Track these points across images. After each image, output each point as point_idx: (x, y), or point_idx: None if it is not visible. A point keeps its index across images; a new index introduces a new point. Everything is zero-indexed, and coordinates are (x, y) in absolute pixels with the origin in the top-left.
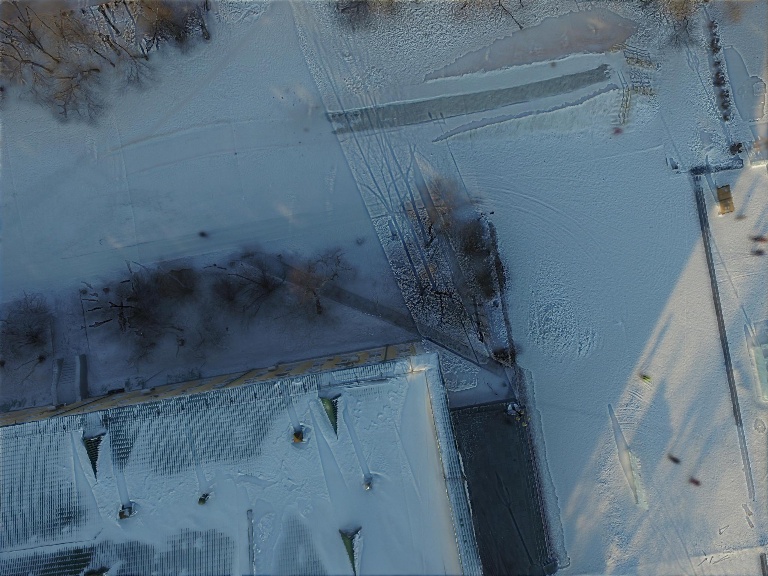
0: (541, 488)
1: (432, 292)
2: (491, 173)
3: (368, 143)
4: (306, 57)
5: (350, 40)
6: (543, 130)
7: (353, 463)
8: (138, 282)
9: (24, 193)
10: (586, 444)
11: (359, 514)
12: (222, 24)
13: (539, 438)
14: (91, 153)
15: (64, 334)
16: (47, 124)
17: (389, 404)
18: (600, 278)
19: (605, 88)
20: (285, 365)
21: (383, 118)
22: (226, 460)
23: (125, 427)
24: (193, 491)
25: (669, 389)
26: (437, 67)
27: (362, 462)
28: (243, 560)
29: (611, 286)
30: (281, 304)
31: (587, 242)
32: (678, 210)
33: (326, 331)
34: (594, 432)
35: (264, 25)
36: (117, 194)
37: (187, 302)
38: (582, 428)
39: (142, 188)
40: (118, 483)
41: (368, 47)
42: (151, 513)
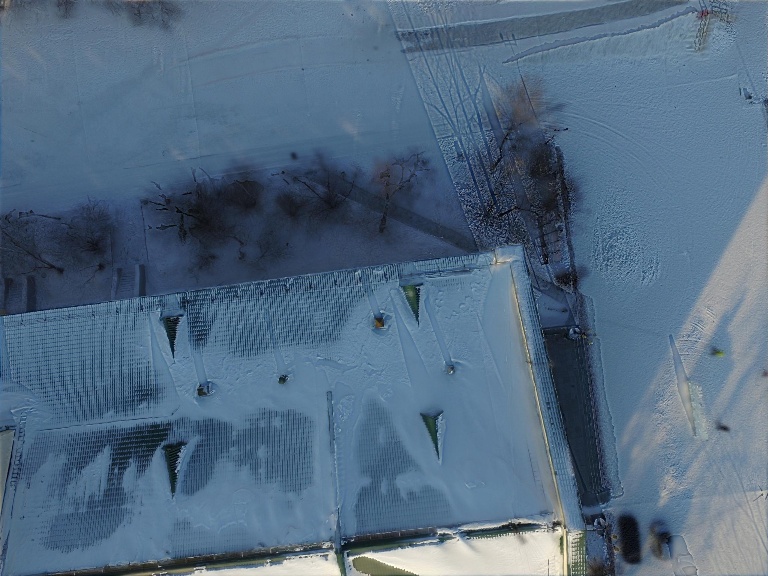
0: (597, 416)
1: (496, 215)
2: (561, 97)
3: (437, 62)
4: None
5: None
6: (616, 55)
7: (434, 350)
8: (201, 193)
9: (89, 102)
10: (645, 374)
11: (441, 399)
12: None
13: (598, 366)
14: (157, 64)
15: (124, 244)
16: (115, 33)
17: (471, 295)
18: (667, 207)
19: (683, 11)
20: None
21: (453, 38)
22: (305, 344)
23: (203, 310)
24: (271, 373)
25: (732, 322)
26: None
27: (443, 350)
28: (323, 438)
29: (678, 215)
30: (343, 221)
31: (655, 170)
32: (749, 141)
33: (387, 250)
34: (654, 362)
35: None
36: (182, 106)
37: (250, 214)
38: (642, 357)
39: (207, 101)
40: (195, 363)
41: None
42: (229, 392)
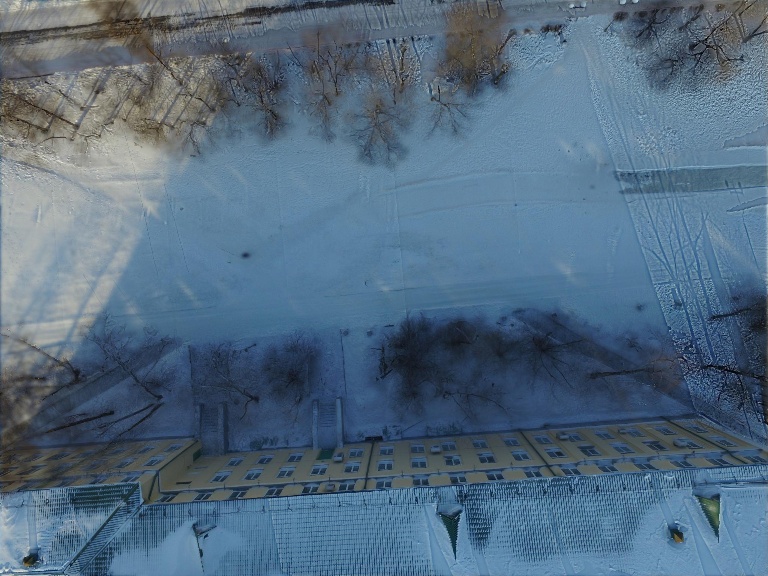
0: None
1: (712, 367)
2: None
3: (658, 206)
4: (597, 111)
5: (646, 98)
6: None
7: (736, 570)
8: (408, 329)
9: (291, 226)
10: None
11: None
12: (511, 69)
13: None
14: (363, 191)
15: (321, 374)
16: (320, 157)
17: None
18: None
19: None
20: (559, 430)
21: (676, 182)
22: (595, 552)
23: (482, 505)
24: None
25: None
26: (738, 134)
27: (747, 570)
28: None
29: None
30: (552, 365)
31: None
32: None
33: (597, 396)
34: None
35: (555, 74)
36: (386, 235)
37: (460, 355)
38: None
39: (413, 231)
40: (479, 565)
41: (665, 107)
42: None
